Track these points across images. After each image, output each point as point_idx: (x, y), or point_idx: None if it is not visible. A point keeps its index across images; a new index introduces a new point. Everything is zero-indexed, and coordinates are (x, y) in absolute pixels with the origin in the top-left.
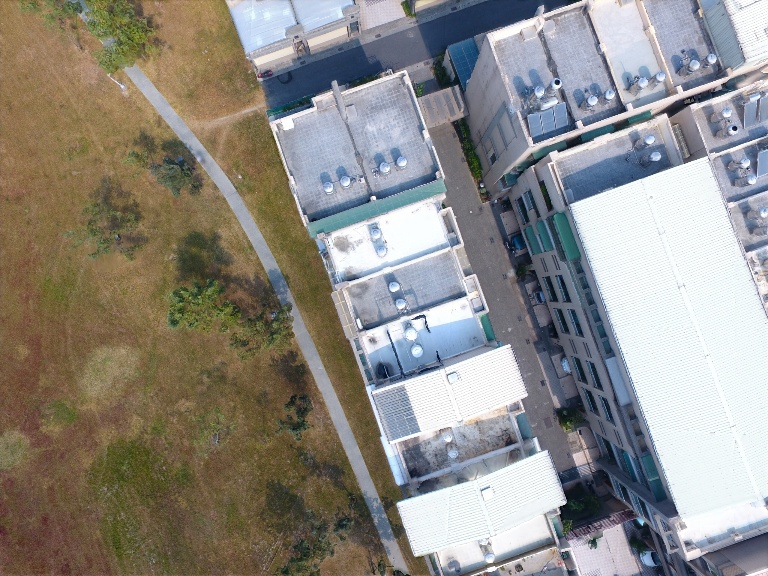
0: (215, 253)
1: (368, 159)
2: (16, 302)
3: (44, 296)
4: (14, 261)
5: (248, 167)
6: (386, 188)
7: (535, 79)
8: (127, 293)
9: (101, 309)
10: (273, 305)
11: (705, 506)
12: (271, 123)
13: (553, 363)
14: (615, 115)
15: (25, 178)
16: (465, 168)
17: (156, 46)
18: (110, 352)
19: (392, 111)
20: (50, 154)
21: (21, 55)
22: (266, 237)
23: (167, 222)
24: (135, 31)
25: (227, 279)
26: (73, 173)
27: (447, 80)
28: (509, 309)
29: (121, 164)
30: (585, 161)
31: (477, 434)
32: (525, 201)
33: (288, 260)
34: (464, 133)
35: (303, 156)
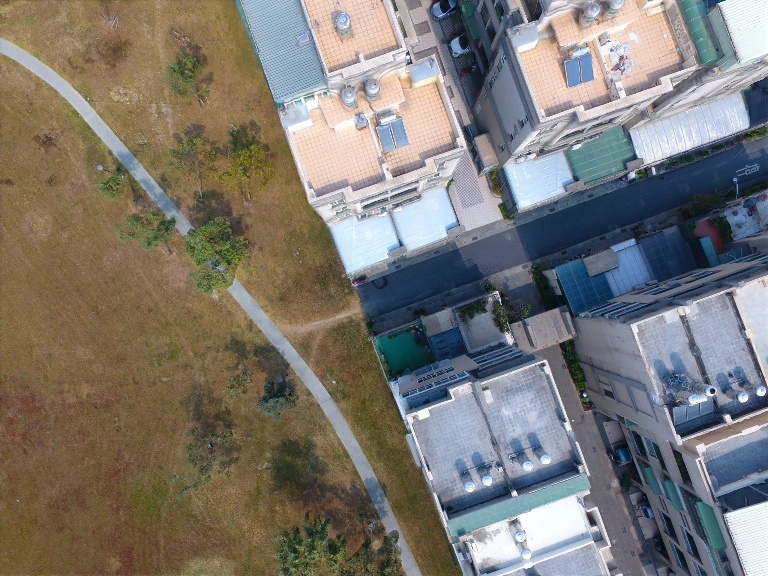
0: (310, 462)
1: (504, 444)
2: (107, 513)
3: (135, 507)
4: (104, 471)
5: (343, 373)
6: (523, 474)
7: (677, 362)
8: (220, 503)
9: (194, 520)
10: (370, 515)
11: None
12: (408, 417)
13: (659, 575)
14: (764, 408)
15: (114, 385)
16: (566, 375)
17: (246, 247)
18: (204, 564)
19: (528, 394)
20: (139, 360)
21: (108, 258)
22: (362, 445)
23: (260, 430)
24: (234, 254)
25: (323, 488)
26: (163, 379)
27: (551, 294)
28: (613, 520)
29: (212, 370)
30: (728, 445)
31: None
32: (646, 444)
33: (385, 468)
34: (568, 346)
35: (437, 442)
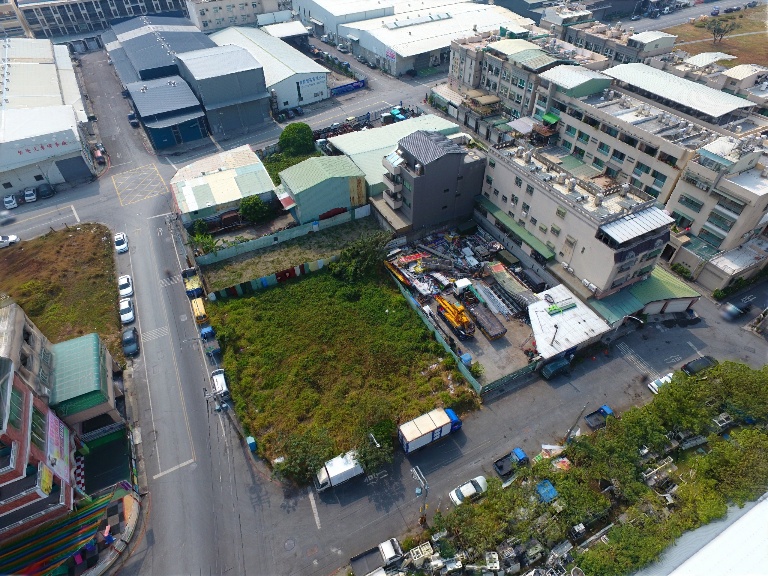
0: None
1: None
2: None
3: None
4: None
5: None
6: None
7: None
8: None
9: None
10: None
11: None
12: None
13: None
14: None
15: None
16: None
17: None
18: None
19: None
20: None
21: None
22: None
23: None
24: None
25: None
26: None
27: None
28: None
29: None
30: None
31: (716, 80)
32: None
33: None
34: None
35: None
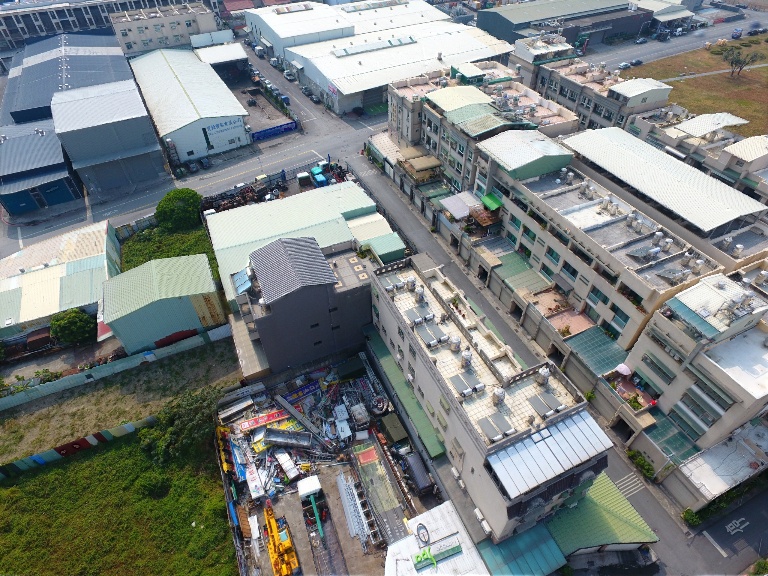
0: None
1: None
2: None
3: None
4: None
5: None
6: None
7: None
8: None
9: None
10: None
11: (610, 129)
12: None
13: None
14: None
15: None
16: None
17: None
18: None
19: None
20: None
21: None
22: None
23: None
24: None
25: None
26: None
27: None
28: None
29: None
30: (761, 247)
31: None
32: None
33: None
34: None
35: None
